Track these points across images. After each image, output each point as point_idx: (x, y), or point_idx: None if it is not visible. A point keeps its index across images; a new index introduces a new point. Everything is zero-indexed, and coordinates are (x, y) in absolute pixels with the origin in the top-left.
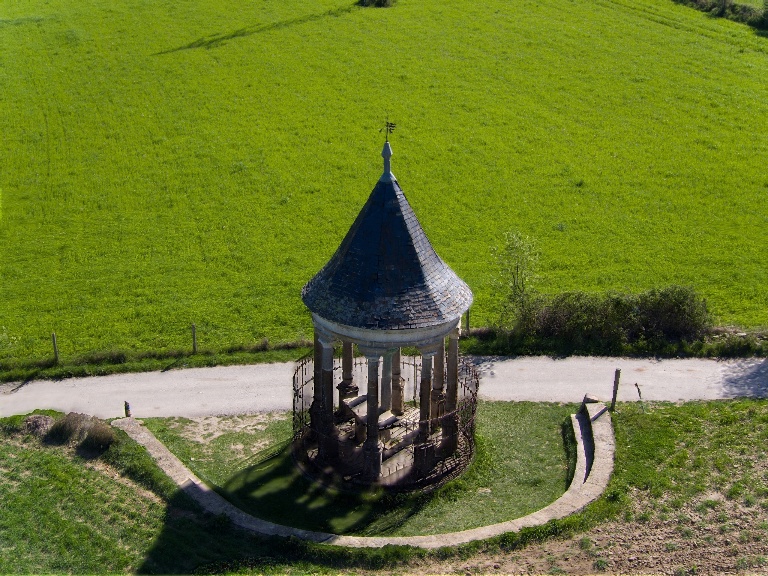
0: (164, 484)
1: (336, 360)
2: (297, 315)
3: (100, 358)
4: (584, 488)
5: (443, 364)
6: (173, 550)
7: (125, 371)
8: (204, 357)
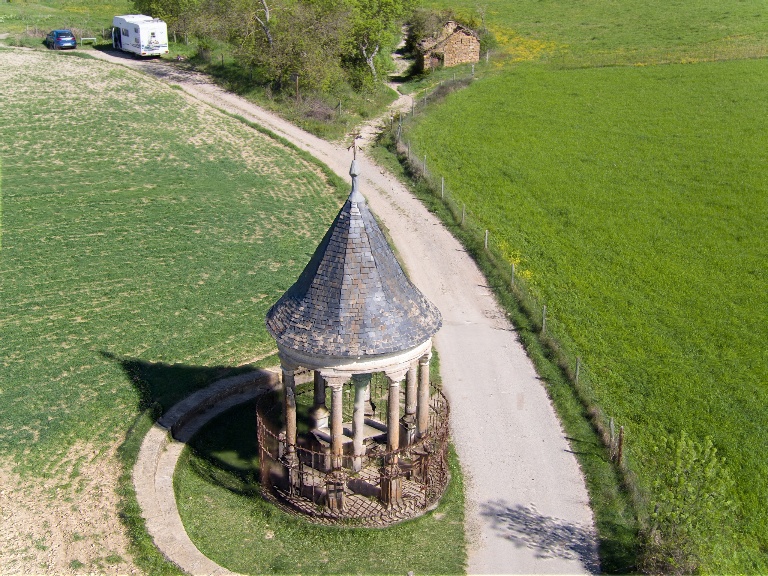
0: (260, 360)
1: (572, 458)
2: (695, 435)
3: (550, 346)
4: (207, 565)
5: (390, 437)
6: (172, 370)
7: (535, 362)
8: (571, 393)
